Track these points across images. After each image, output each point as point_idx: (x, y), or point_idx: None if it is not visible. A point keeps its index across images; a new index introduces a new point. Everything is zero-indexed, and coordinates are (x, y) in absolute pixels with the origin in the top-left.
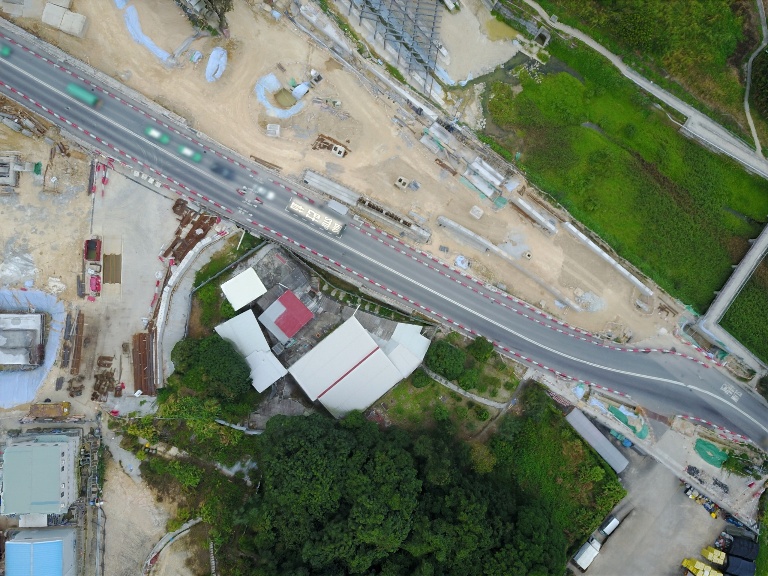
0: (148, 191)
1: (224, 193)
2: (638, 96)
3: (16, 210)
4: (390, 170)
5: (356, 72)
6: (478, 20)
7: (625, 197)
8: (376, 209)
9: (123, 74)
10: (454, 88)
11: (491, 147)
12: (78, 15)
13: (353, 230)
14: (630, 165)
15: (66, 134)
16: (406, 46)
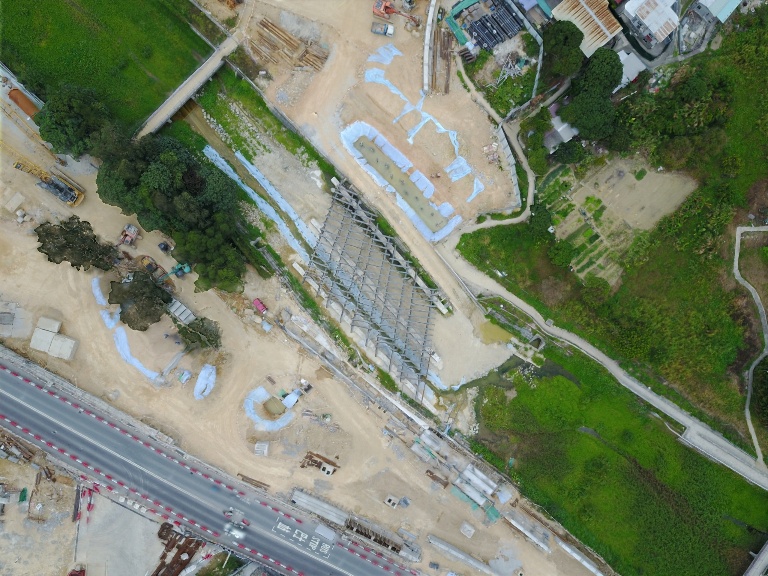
0: (133, 515)
1: (210, 515)
2: (635, 406)
3: (0, 538)
4: (379, 488)
5: (347, 380)
6: (472, 323)
7: (621, 506)
8: (364, 535)
9: (111, 393)
10: (446, 393)
11: (483, 457)
12: (66, 340)
13: (341, 549)
14: (627, 473)
15: (52, 459)
16: (398, 352)
